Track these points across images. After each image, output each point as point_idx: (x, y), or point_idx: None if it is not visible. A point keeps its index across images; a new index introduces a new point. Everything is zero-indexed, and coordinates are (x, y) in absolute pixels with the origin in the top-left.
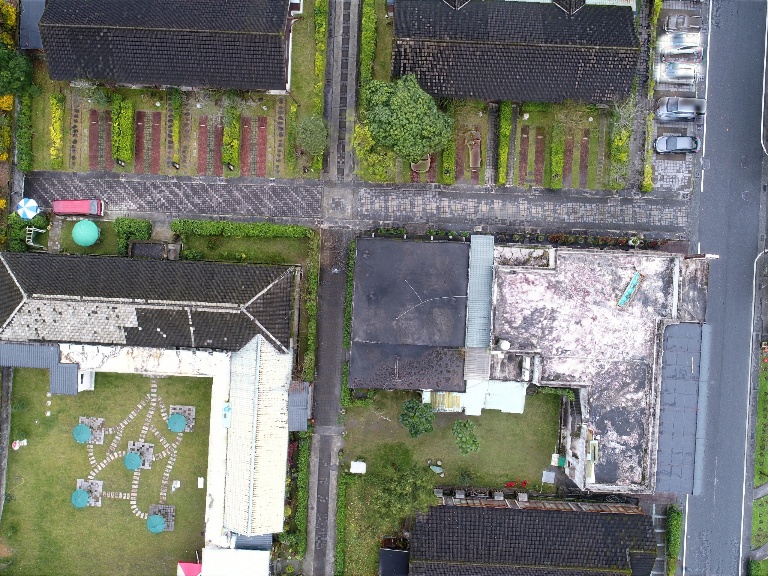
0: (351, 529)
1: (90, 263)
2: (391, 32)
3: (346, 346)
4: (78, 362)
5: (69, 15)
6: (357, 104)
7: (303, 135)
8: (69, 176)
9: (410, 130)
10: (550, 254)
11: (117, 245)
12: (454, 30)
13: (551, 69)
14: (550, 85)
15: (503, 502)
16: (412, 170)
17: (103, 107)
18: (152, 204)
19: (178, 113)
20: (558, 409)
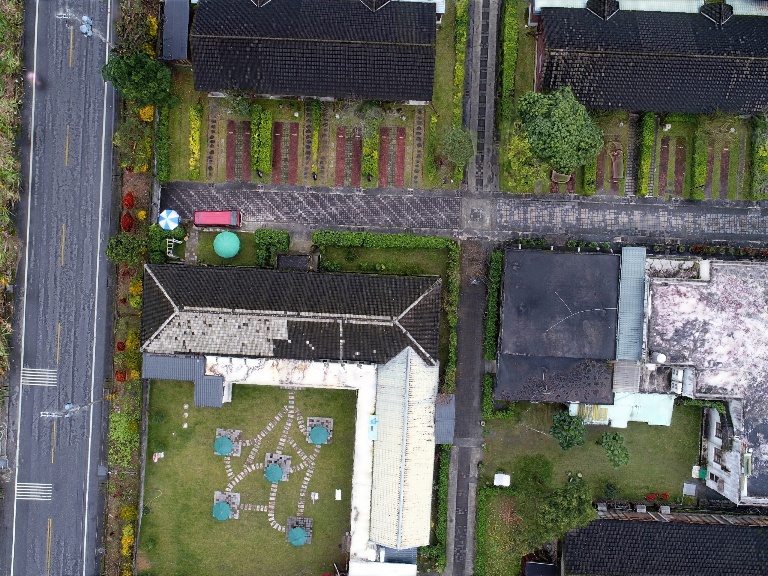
0: (491, 542)
1: (237, 275)
2: (531, 42)
3: (488, 358)
4: (223, 374)
5: (218, 26)
6: (496, 114)
7: (451, 146)
8: (206, 187)
9: (570, 142)
10: (702, 266)
11: (254, 256)
12: (606, 41)
13: (703, 80)
14: (700, 96)
15: (647, 515)
16: (551, 181)
17: (240, 117)
18: (289, 215)
19: (318, 124)
20: (699, 421)
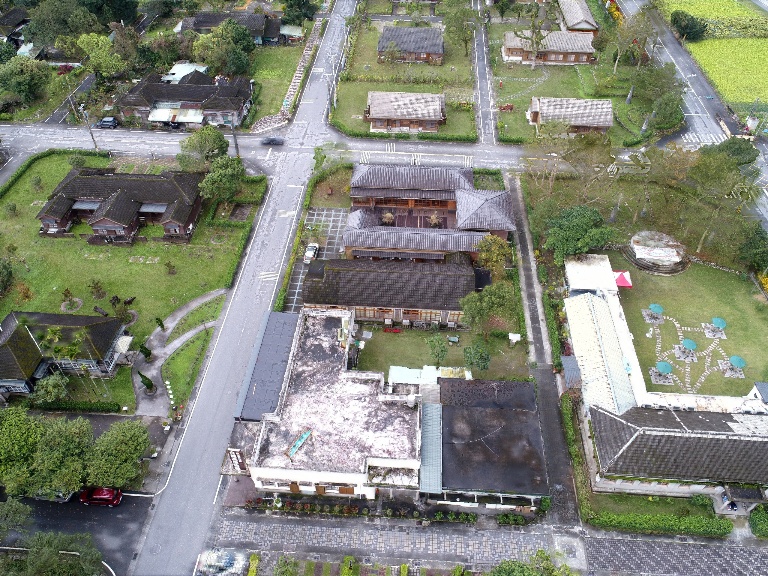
0: None
1: None
2: None
3: None
4: (766, 405)
5: None
6: None
7: None
8: None
9: None
10: None
11: None
12: None
13: None
14: None
15: (404, 317)
16: None
17: None
18: (761, 556)
19: None
20: None
